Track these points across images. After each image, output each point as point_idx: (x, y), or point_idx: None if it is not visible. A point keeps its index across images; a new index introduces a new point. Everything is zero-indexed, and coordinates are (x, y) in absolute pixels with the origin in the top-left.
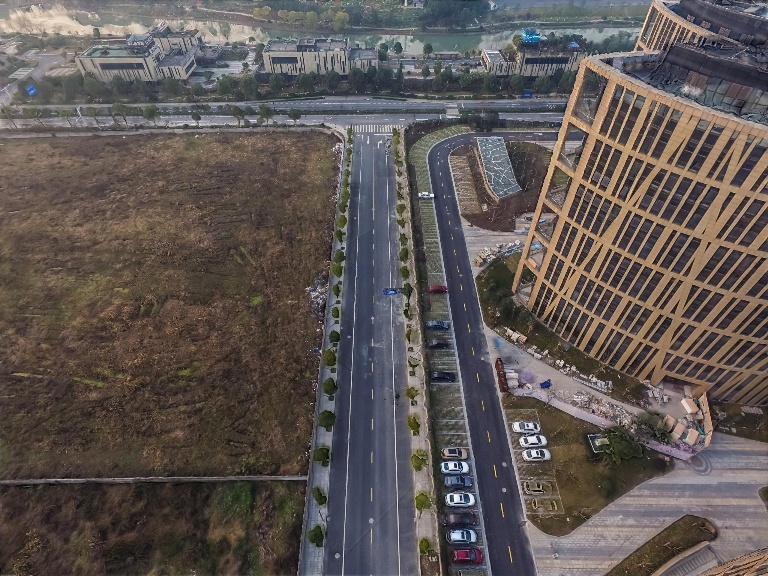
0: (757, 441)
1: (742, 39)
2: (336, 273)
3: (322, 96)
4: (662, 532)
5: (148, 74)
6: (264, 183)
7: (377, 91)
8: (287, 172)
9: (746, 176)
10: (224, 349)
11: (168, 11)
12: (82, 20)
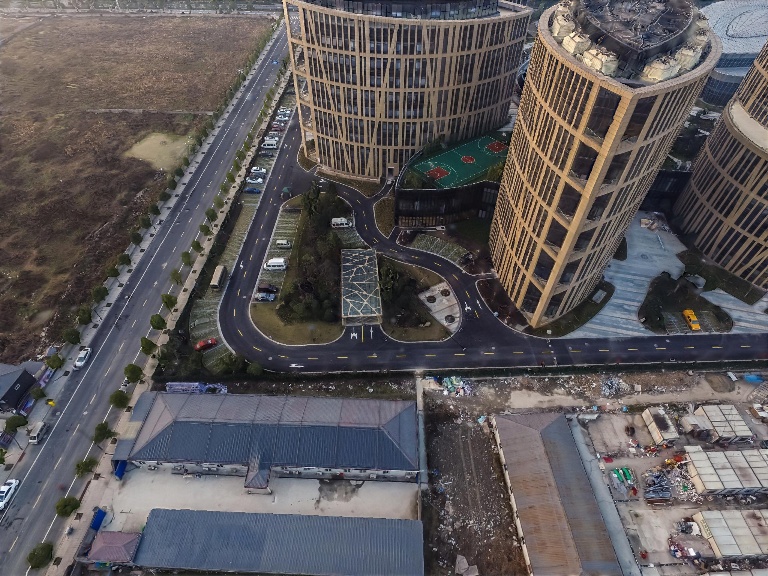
0: None
1: None
2: (251, 59)
3: (273, 3)
4: None
5: None
6: (225, 36)
7: None
8: (240, 33)
9: None
10: (189, 84)
11: None
12: None
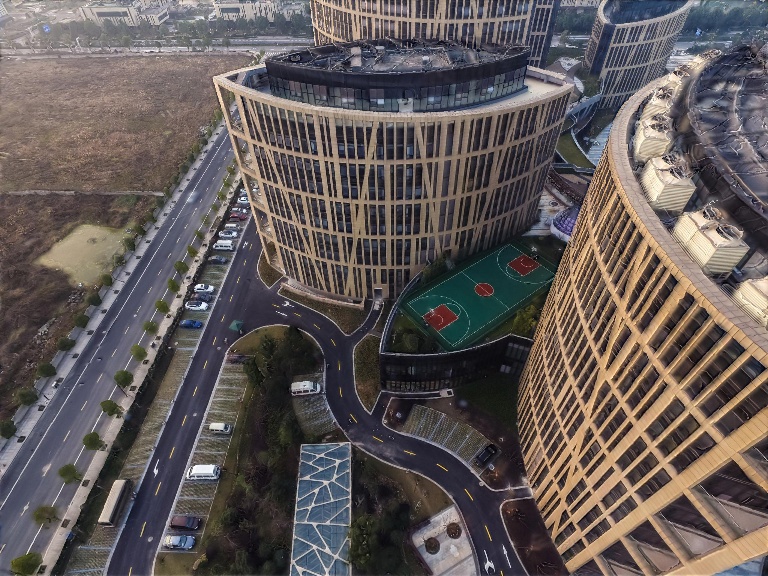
0: None
1: None
2: (217, 116)
3: (255, 36)
4: None
5: (131, 20)
6: (194, 81)
7: (297, 32)
8: None
9: (355, 3)
10: (140, 150)
11: None
12: None
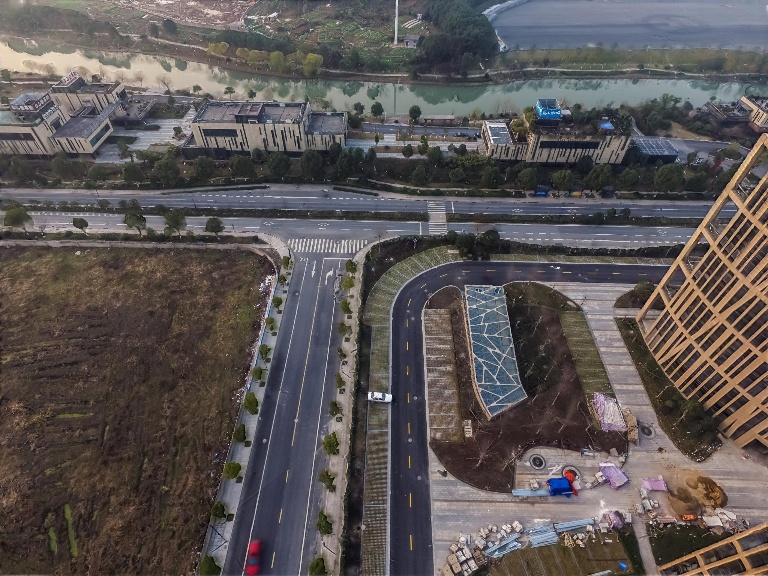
0: None
1: None
2: None
3: (266, 184)
4: None
5: (41, 146)
6: (143, 356)
7: (340, 179)
8: (183, 332)
9: None
10: None
11: (112, 41)
12: (17, 46)
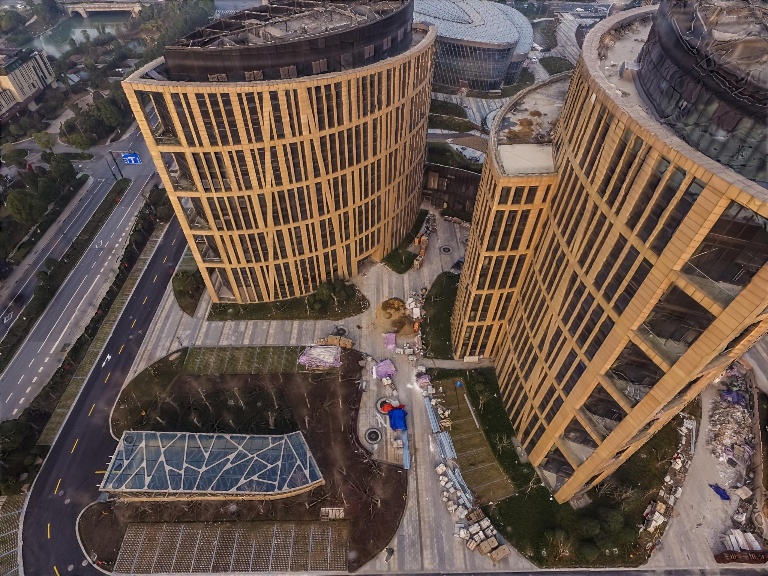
0: None
1: (316, 69)
2: None
3: None
4: None
5: None
6: None
7: None
8: None
9: None
10: None
11: None
12: None
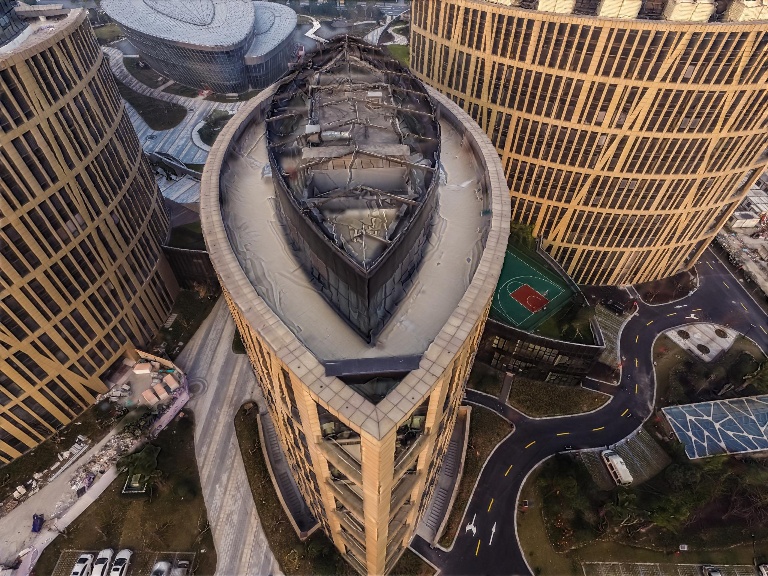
0: (196, 332)
1: None
2: None
3: None
4: (241, 450)
5: None
6: None
7: None
8: None
9: None
10: None
11: None
12: None
